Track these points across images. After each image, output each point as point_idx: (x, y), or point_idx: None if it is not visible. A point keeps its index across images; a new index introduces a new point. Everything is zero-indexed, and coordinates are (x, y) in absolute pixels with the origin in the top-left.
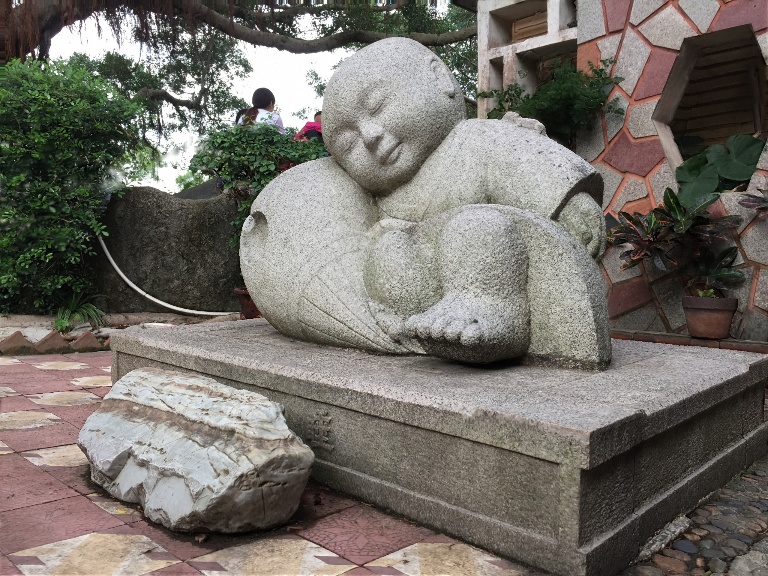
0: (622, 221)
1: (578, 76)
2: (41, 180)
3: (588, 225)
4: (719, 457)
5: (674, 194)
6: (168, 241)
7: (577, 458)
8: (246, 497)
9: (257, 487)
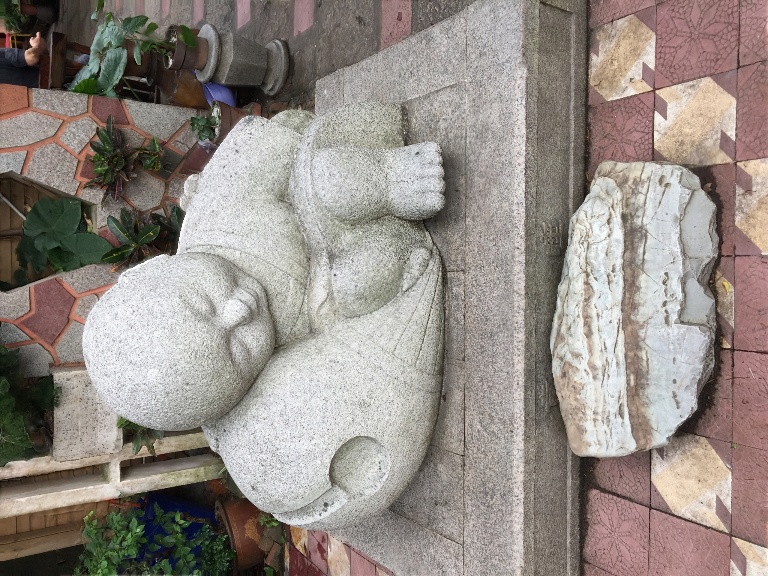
0: None
1: None
2: None
3: None
4: None
5: (109, 252)
6: None
7: None
8: None
9: None
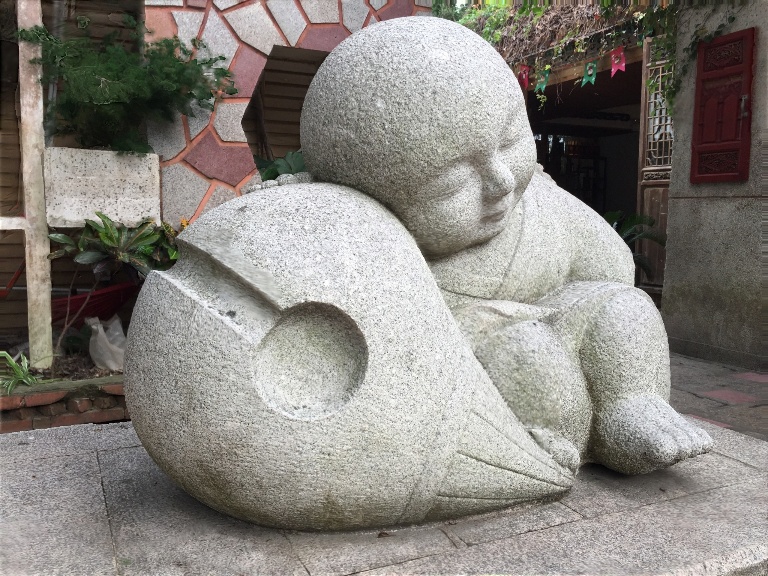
0: None
1: None
2: None
3: None
4: None
5: None
6: None
7: None
8: None
9: None
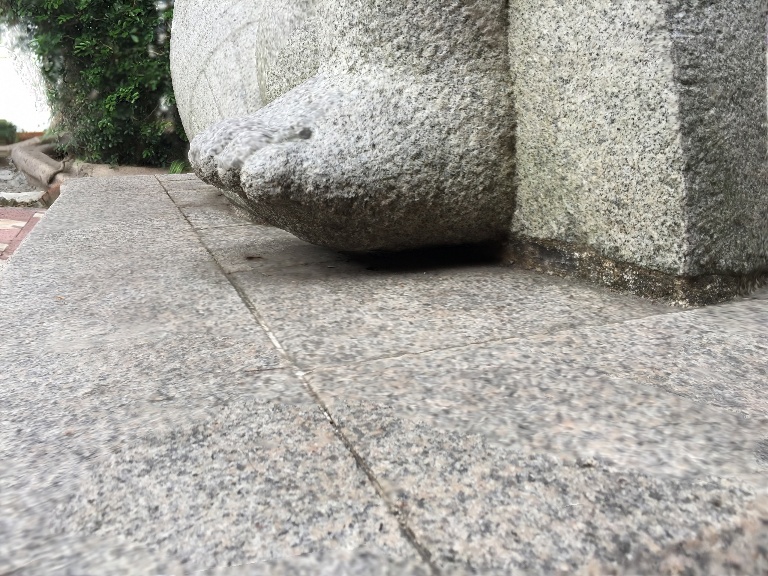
0: None
1: None
2: (122, 3)
3: None
4: None
5: None
6: None
7: None
8: None
9: None
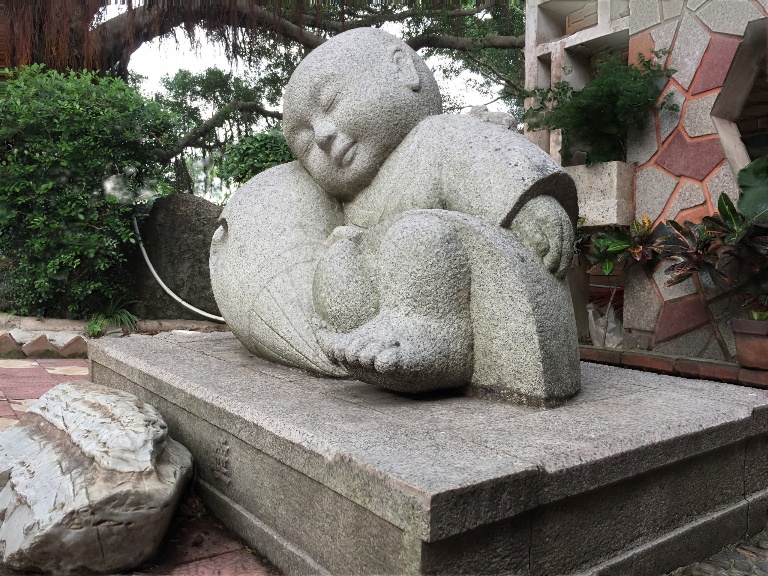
0: (670, 231)
1: (626, 70)
2: (72, 188)
3: (545, 234)
4: (696, 523)
5: (729, 200)
6: (205, 249)
7: (418, 526)
8: (75, 537)
9: (91, 526)
